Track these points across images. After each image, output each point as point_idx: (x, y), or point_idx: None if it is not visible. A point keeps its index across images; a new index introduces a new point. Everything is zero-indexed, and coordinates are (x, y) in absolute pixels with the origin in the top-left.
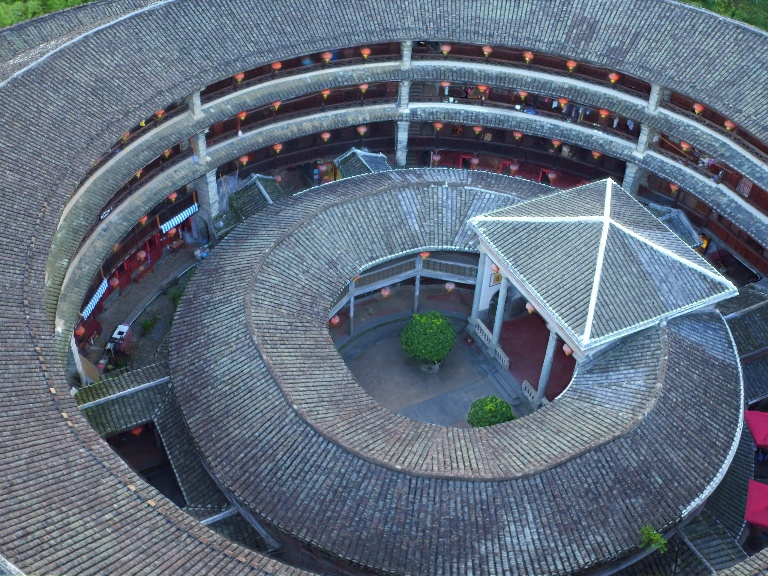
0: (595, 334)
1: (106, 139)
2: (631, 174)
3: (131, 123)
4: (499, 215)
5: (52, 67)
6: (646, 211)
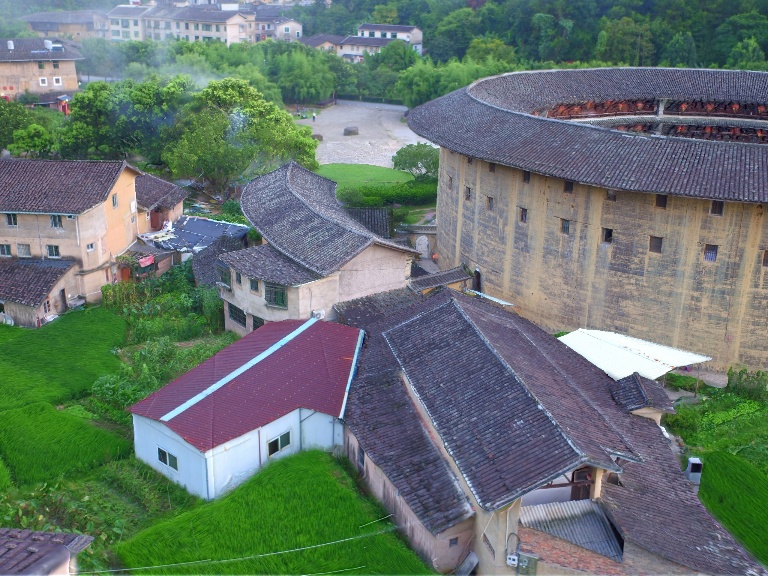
0: None
1: (741, 98)
2: None
3: (760, 100)
4: None
5: (766, 76)
6: None
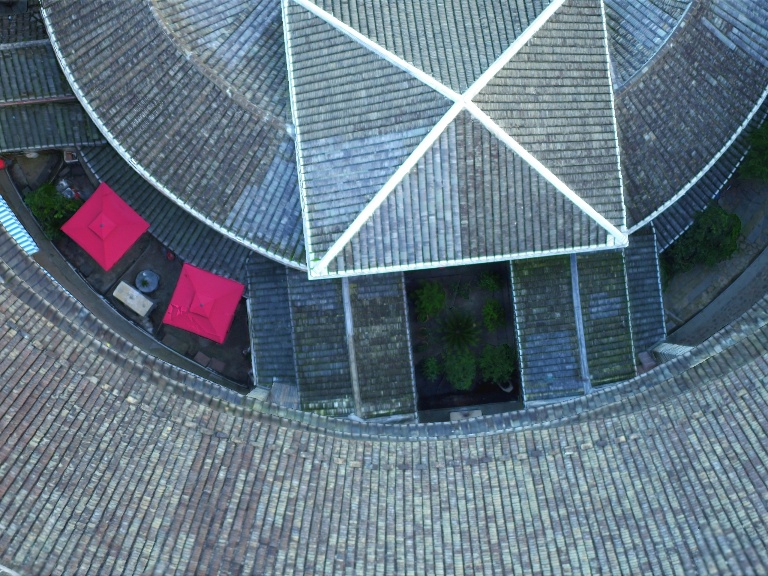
0: (293, 9)
1: None
2: (683, 351)
3: None
4: (585, 0)
5: None
6: (523, 247)
